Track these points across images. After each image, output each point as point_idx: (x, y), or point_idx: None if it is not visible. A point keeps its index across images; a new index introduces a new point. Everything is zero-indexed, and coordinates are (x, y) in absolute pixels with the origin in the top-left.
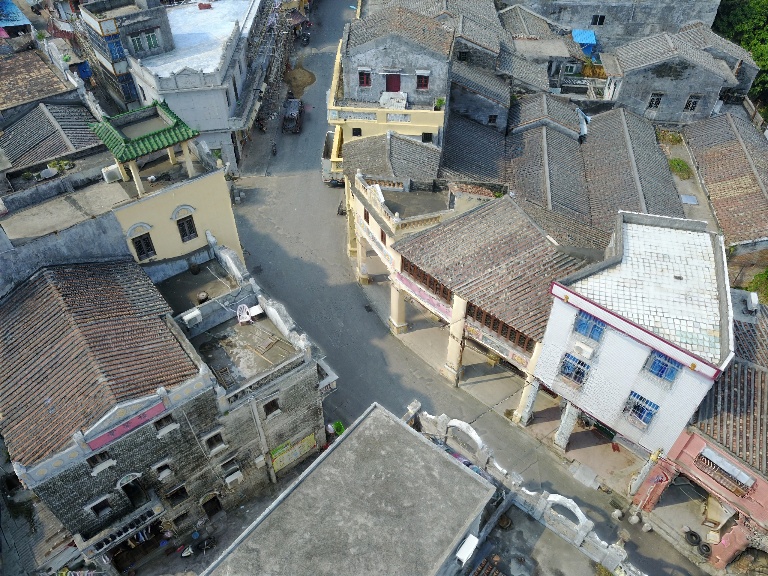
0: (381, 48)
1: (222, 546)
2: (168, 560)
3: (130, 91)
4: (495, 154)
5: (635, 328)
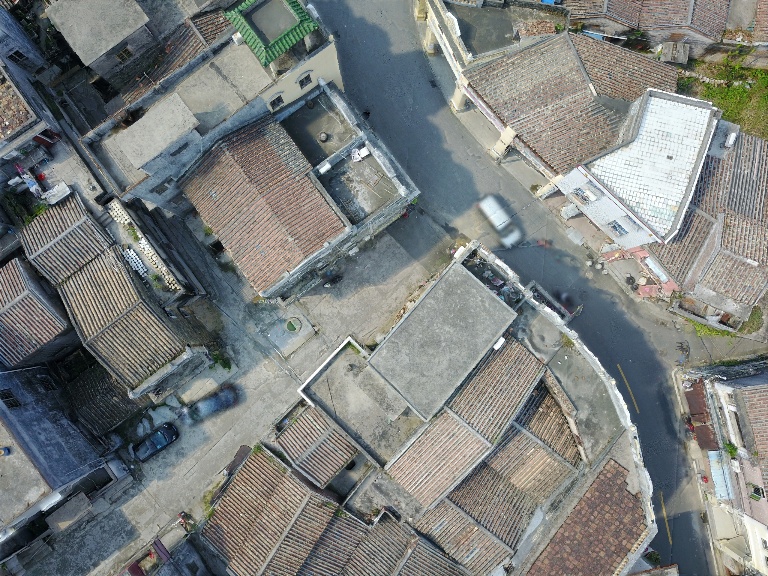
0: None
1: (345, 279)
2: (315, 287)
3: None
4: None
5: (624, 207)
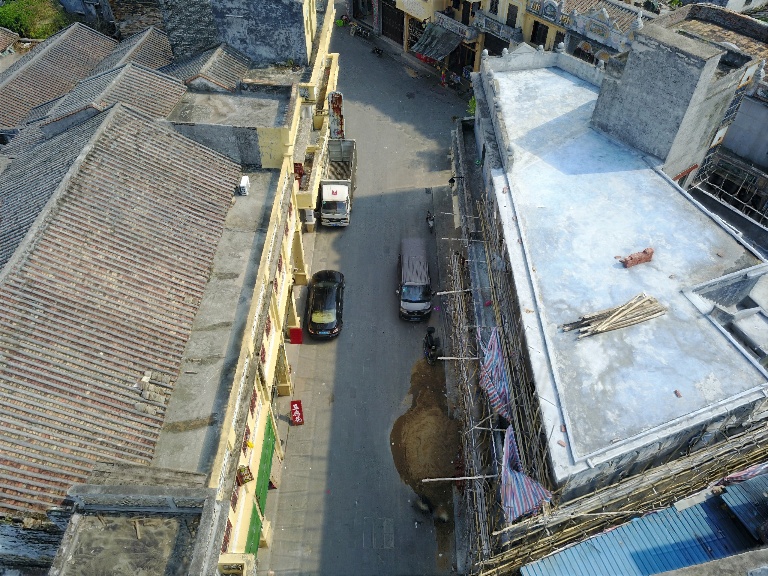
0: None
1: None
2: None
3: None
4: None
5: None
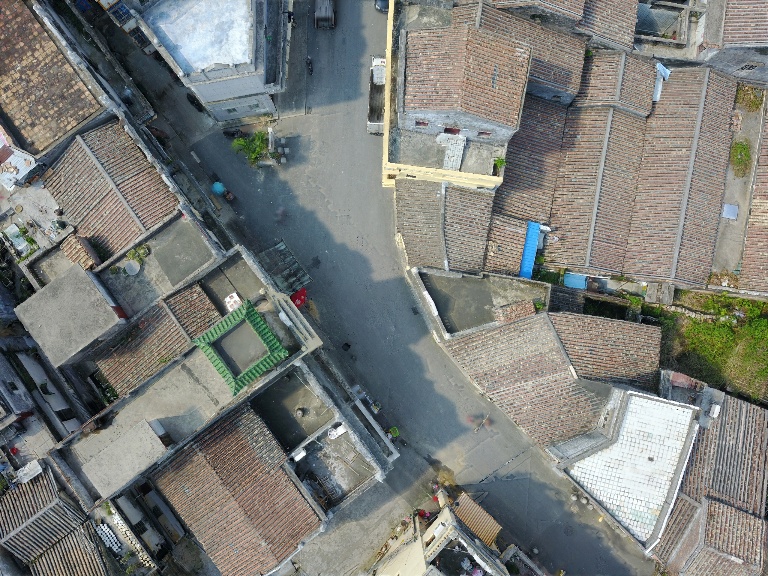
0: (443, 115)
1: None
2: None
3: (143, 36)
4: (551, 147)
5: None
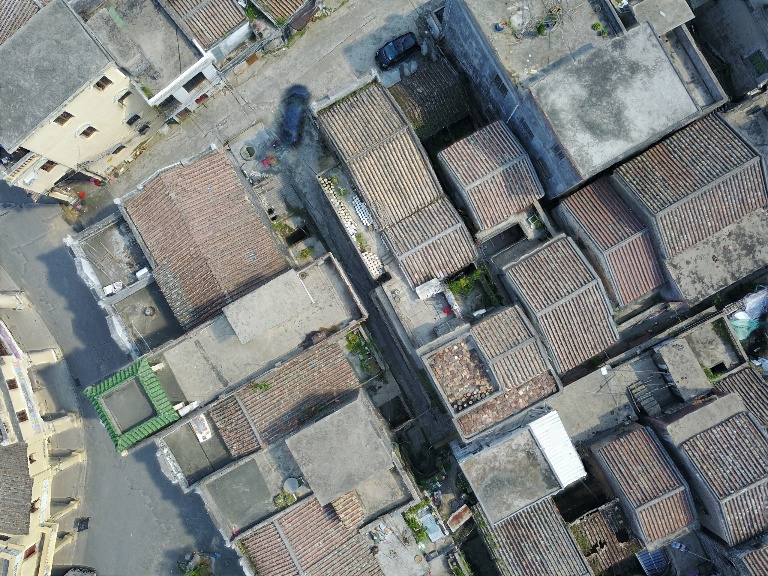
0: None
1: None
2: None
3: None
4: None
5: None
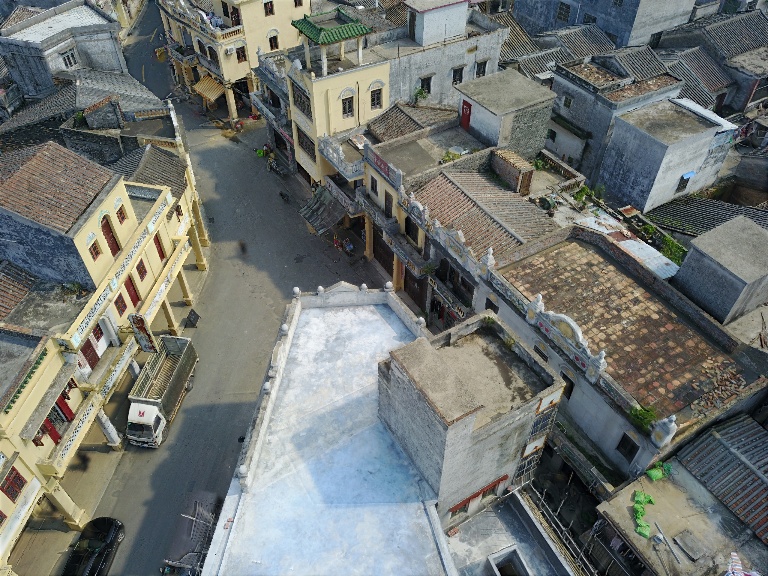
0: None
1: None
2: None
3: None
4: None
5: None
